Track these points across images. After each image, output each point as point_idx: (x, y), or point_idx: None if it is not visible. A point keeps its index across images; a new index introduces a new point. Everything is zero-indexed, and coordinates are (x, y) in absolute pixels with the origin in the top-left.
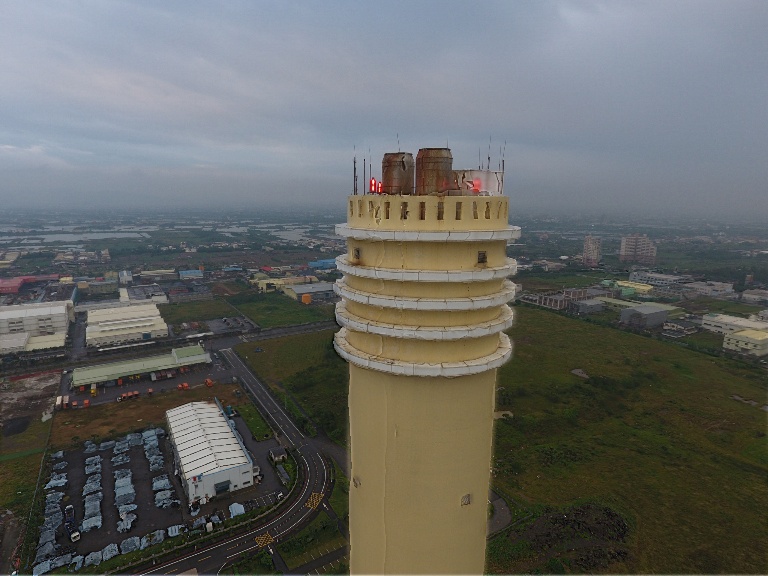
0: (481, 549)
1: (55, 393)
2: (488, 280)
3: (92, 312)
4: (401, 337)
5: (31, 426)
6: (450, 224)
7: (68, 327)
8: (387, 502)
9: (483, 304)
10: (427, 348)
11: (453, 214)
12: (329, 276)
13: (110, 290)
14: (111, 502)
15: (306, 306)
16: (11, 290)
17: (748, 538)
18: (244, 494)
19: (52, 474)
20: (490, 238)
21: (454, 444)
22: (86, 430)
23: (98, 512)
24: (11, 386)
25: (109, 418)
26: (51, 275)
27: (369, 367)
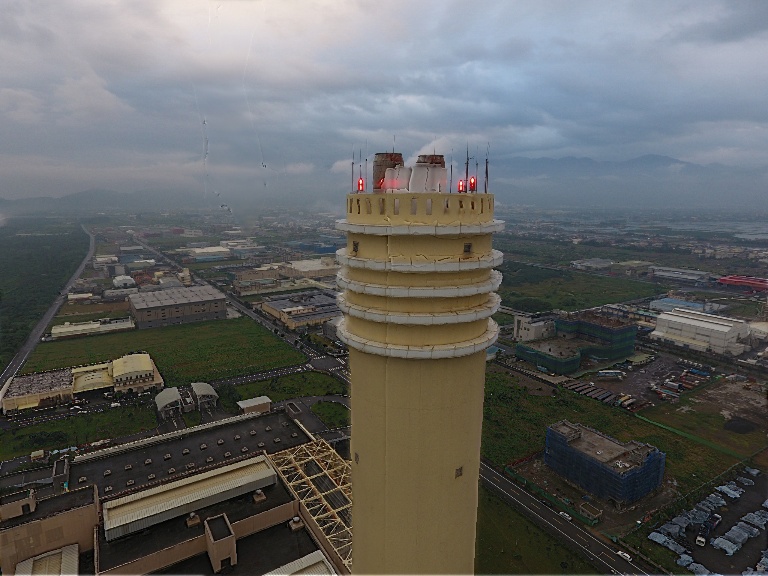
0: (376, 531)
1: None
2: (358, 268)
3: None
4: None
5: (753, 433)
6: None
7: None
8: None
9: None
10: None
11: None
12: None
13: None
14: (761, 547)
15: None
16: None
17: None
18: None
19: (731, 482)
20: None
21: None
22: None
23: (739, 542)
24: (767, 392)
25: None
26: None
27: None
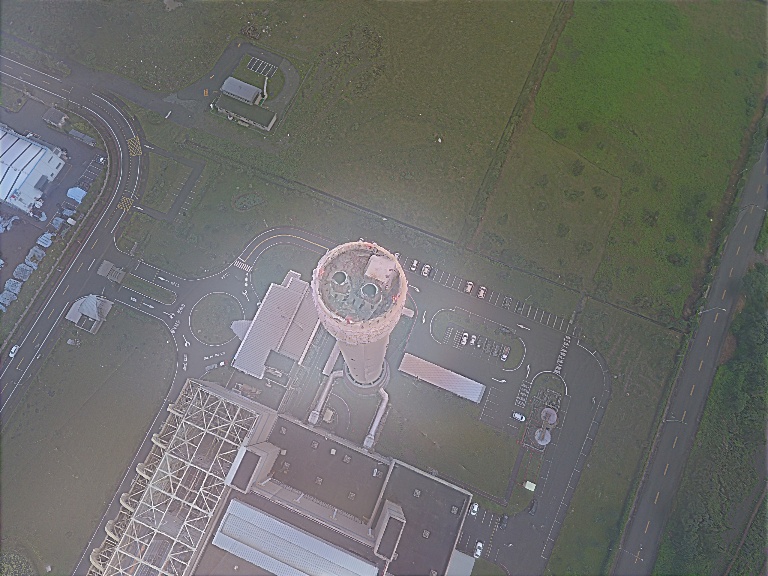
0: None
1: None
2: None
3: None
4: None
5: None
6: None
7: None
8: None
9: None
10: None
11: None
12: None
13: None
14: None
15: None
16: None
17: (458, 5)
18: (67, 176)
19: None
20: None
21: None
22: None
23: None
24: None
25: None
26: None
27: None
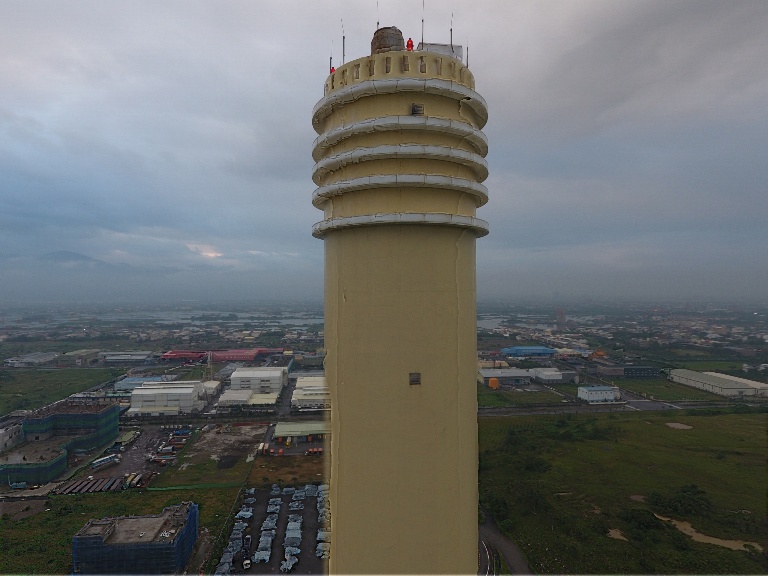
0: (449, 459)
1: (260, 441)
2: (427, 132)
3: (301, 379)
4: (341, 192)
5: (238, 464)
6: (379, 77)
7: (281, 389)
8: (339, 376)
9: (413, 149)
10: (363, 200)
11: (383, 69)
12: (522, 363)
13: (318, 363)
14: (281, 542)
15: (493, 390)
16: (249, 358)
17: None
18: None
19: (243, 506)
20: (424, 88)
21: (397, 308)
22: (276, 475)
23: (269, 547)
24: (232, 430)
25: (295, 468)
26: (278, 348)
27: (319, 229)
